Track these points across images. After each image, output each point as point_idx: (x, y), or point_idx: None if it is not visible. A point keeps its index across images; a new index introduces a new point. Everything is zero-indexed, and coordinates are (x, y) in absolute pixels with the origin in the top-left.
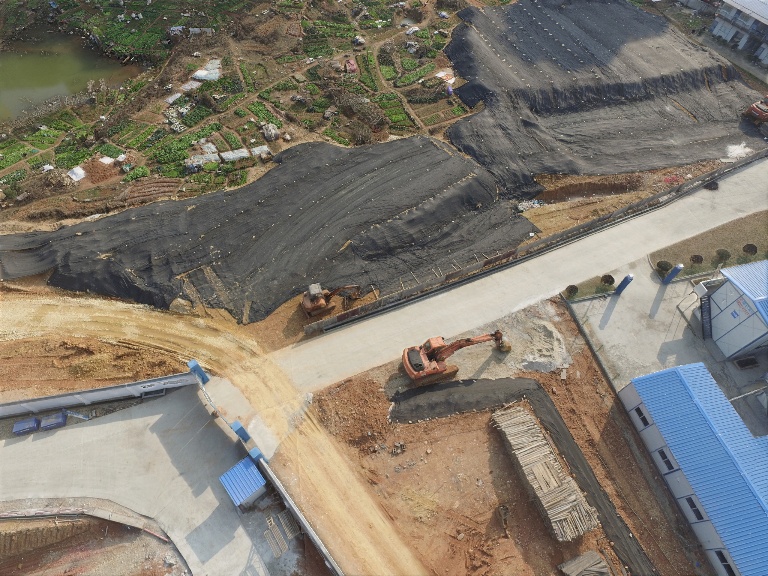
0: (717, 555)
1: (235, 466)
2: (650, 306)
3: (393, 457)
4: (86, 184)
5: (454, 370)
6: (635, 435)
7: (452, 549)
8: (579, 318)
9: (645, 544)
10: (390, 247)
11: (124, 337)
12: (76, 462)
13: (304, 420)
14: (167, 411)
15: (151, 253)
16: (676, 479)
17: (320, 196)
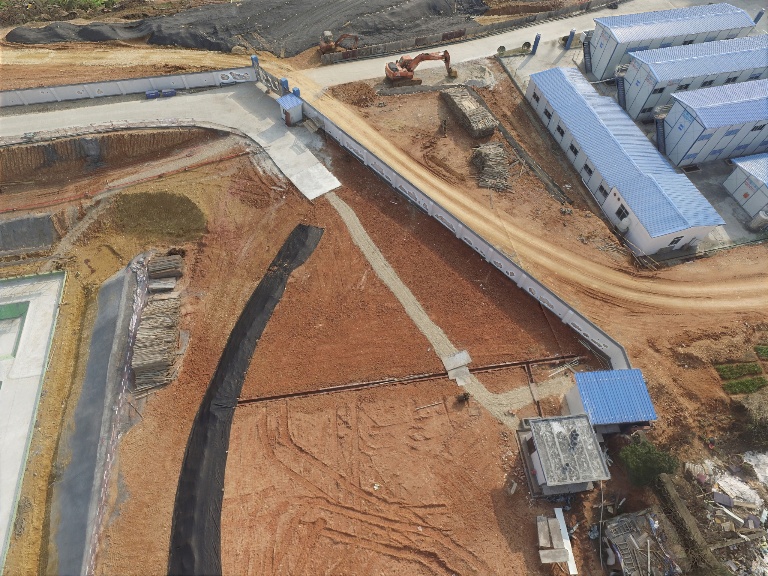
0: (571, 149)
1: (284, 96)
2: (554, 59)
3: (379, 108)
4: (160, 1)
5: (419, 80)
6: (533, 113)
7: (413, 141)
8: (505, 64)
9: (531, 153)
10: (378, 27)
11: (204, 64)
12: (186, 108)
13: (323, 96)
14: (238, 91)
15: (215, 25)
16: (552, 122)
17: (328, 1)
